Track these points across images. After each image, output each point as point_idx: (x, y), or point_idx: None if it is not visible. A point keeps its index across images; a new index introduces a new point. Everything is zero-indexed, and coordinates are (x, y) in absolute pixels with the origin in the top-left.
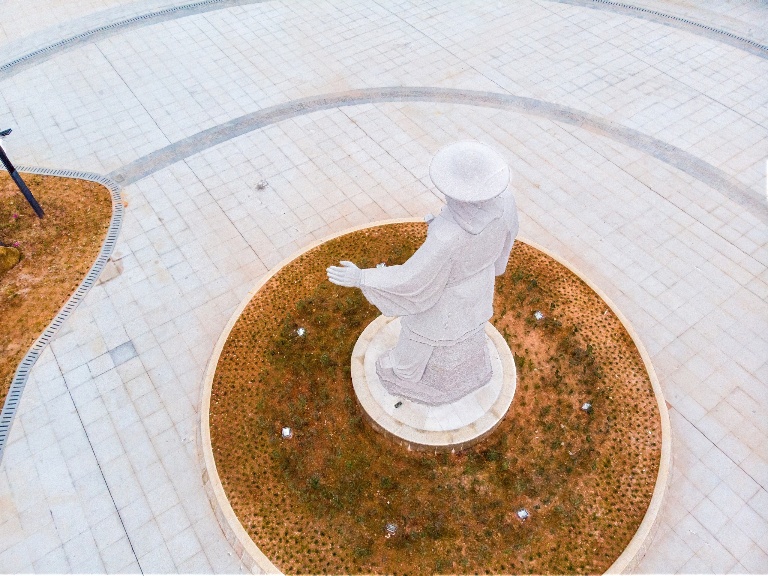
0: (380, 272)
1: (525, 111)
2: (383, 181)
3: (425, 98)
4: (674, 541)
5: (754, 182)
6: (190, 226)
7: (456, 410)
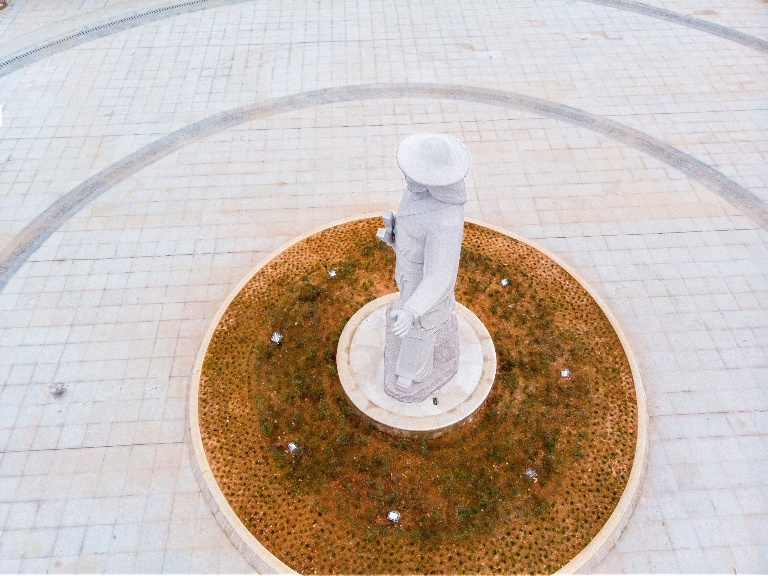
0: (421, 295)
1: (196, 138)
2: (167, 281)
3: (100, 190)
4: (616, 303)
5: (391, 78)
6: (39, 499)
7: (466, 362)
